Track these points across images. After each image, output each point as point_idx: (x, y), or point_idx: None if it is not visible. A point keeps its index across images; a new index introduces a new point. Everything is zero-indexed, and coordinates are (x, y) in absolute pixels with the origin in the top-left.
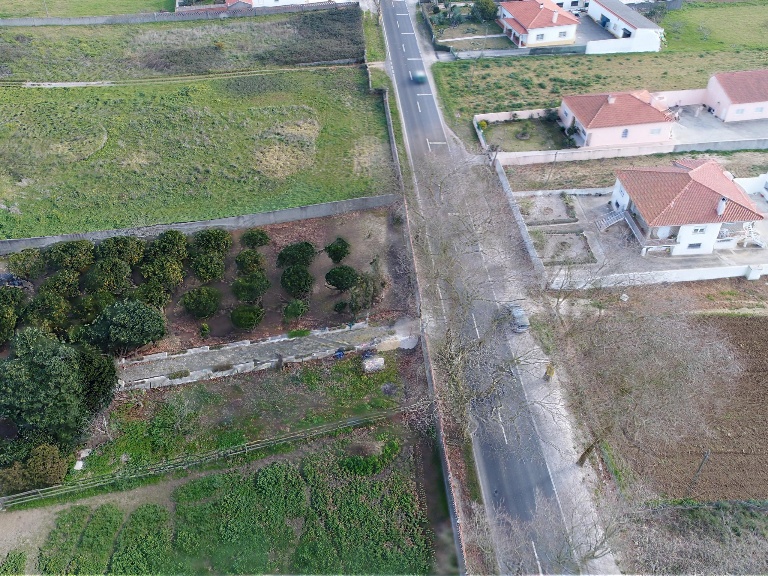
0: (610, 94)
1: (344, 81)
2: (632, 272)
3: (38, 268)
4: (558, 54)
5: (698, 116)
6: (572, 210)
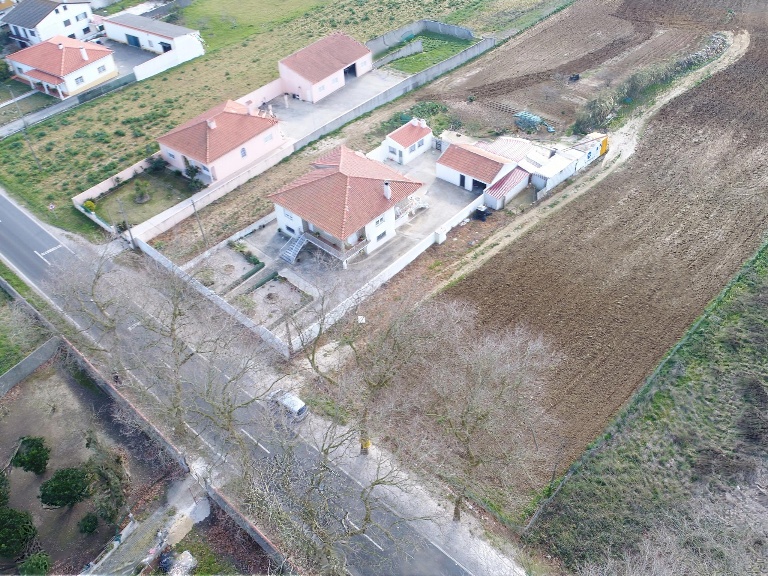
0: (206, 119)
1: None
2: (354, 292)
3: None
4: (110, 92)
5: (289, 106)
6: (251, 256)
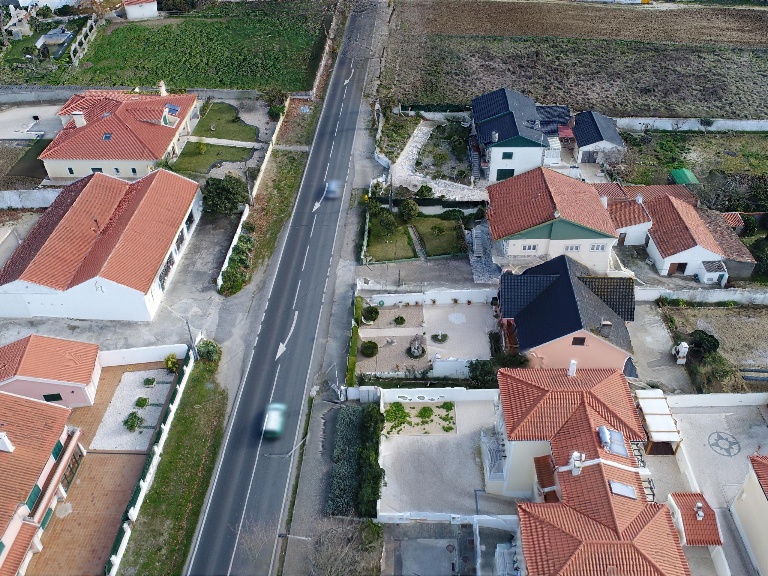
0: None
1: None
2: None
3: None
4: None
5: None
6: None
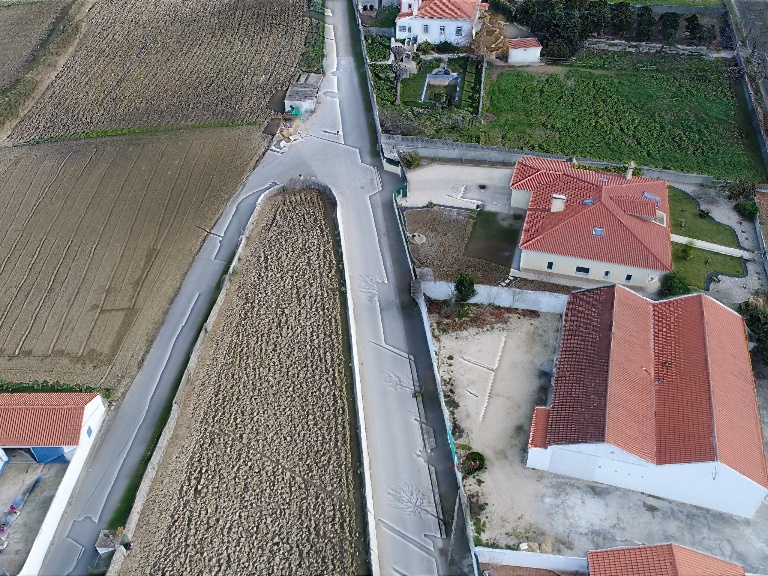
0: None
1: None
2: None
3: (539, 3)
4: None
5: None
6: None
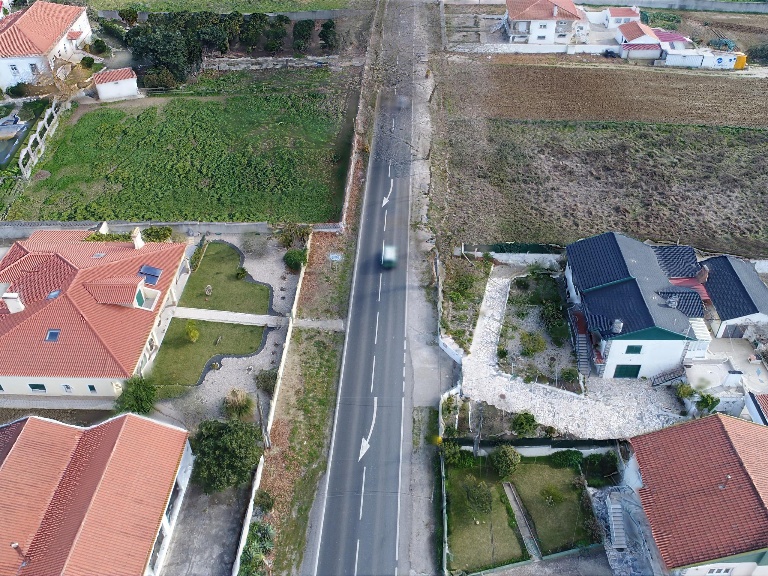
0: None
1: None
2: (496, 43)
3: (163, 22)
4: None
5: None
6: (478, 23)
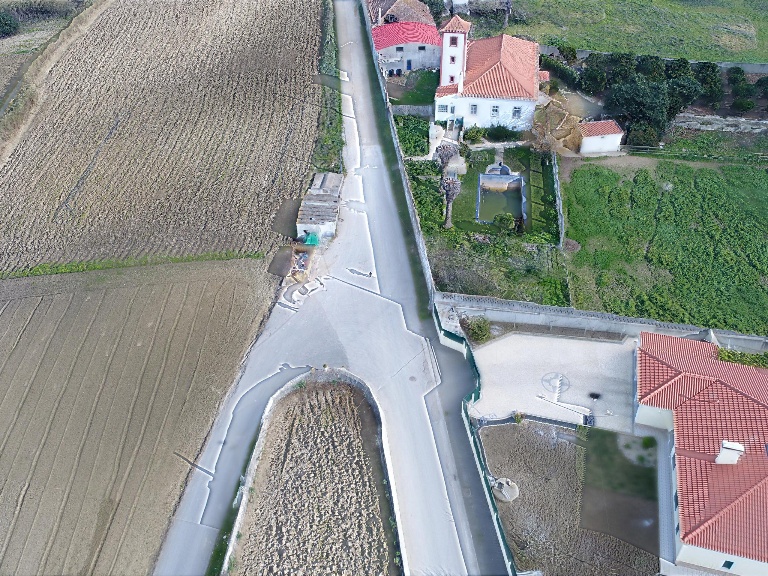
0: None
1: (767, 6)
2: None
3: (604, 63)
4: None
5: None
6: None
